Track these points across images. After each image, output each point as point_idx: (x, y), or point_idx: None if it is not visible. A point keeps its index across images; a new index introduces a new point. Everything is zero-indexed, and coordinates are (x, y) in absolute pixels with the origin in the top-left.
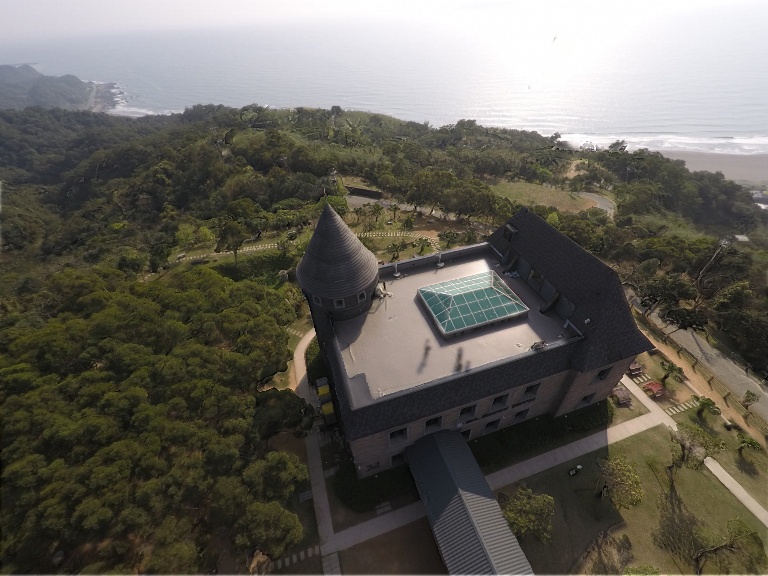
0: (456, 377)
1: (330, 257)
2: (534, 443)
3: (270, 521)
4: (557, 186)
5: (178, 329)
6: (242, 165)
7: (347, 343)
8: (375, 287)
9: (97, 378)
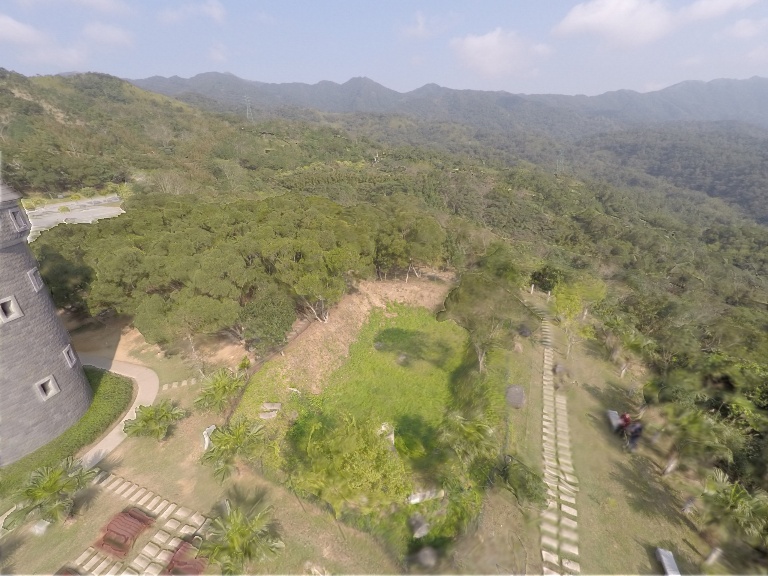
0: None
1: None
2: None
3: None
4: None
5: (212, 223)
6: None
7: None
8: None
9: None
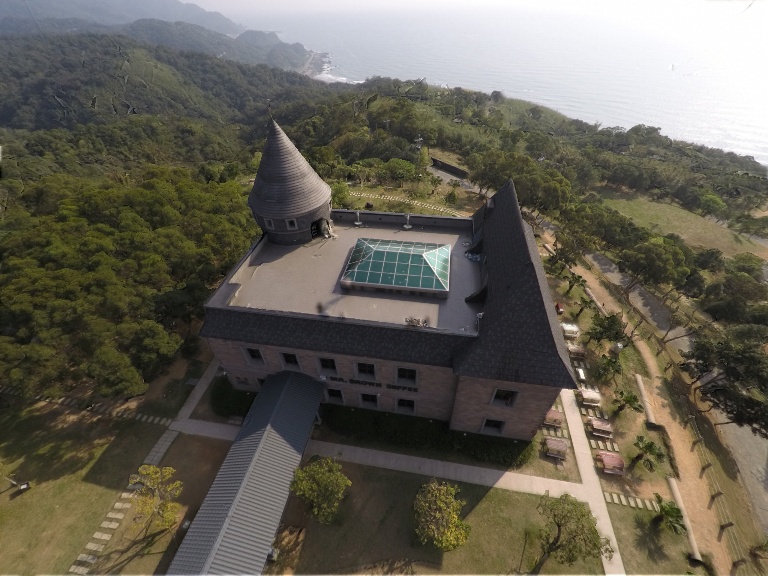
0: (307, 316)
1: (267, 174)
2: (407, 440)
3: (107, 363)
4: (725, 222)
5: (169, 214)
6: (361, 125)
7: (262, 262)
8: (321, 224)
9: (106, 231)
